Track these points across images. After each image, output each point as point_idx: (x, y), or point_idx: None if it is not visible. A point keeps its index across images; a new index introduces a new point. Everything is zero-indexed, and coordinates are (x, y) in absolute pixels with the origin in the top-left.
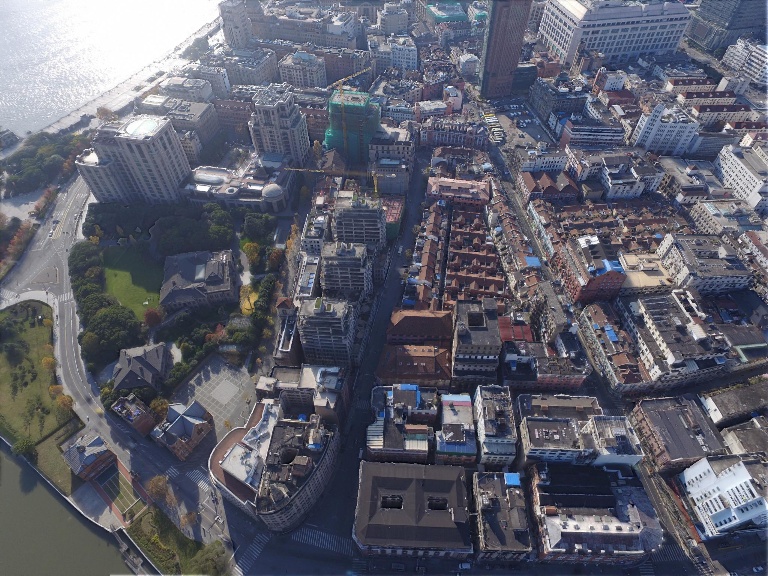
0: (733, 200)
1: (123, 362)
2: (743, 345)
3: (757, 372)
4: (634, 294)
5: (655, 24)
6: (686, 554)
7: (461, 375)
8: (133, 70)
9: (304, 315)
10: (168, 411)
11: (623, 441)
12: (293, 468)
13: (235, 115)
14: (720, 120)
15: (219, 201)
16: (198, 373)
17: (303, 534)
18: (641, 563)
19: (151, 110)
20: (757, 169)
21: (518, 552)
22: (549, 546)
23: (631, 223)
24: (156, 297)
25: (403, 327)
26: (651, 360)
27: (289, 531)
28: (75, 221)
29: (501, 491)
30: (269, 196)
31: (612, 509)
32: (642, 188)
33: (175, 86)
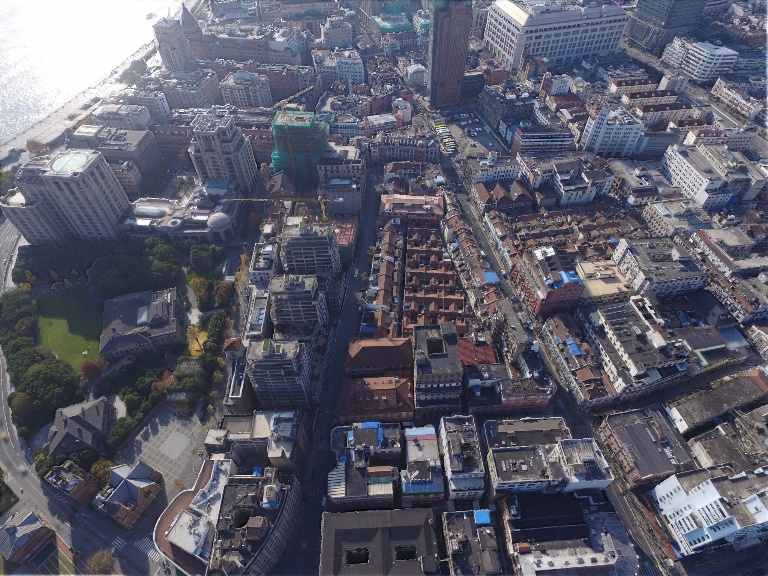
0: (682, 199)
1: (59, 423)
2: (702, 348)
3: (718, 373)
4: (593, 303)
5: (595, 26)
6: (664, 575)
7: (424, 405)
8: (66, 98)
9: (252, 359)
10: (110, 475)
11: (591, 466)
12: (247, 532)
13: (176, 141)
14: (664, 119)
15: (162, 234)
16: (145, 427)
17: None
18: None
19: (84, 141)
20: (702, 167)
21: None
22: None
23: (586, 229)
24: (96, 345)
25: (361, 359)
26: (615, 372)
27: None
28: (4, 267)
29: (471, 531)
30: (215, 226)
31: (586, 539)
32: (594, 192)
33: (109, 114)
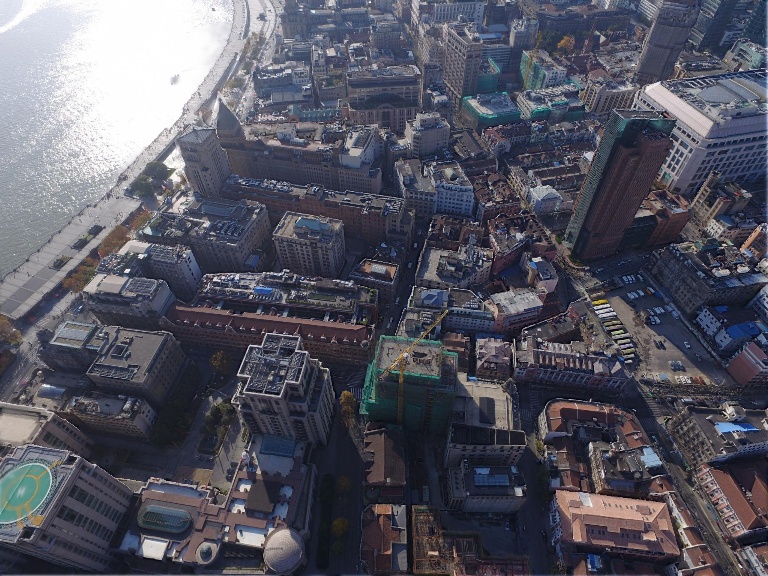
0: None
1: None
2: None
3: None
4: None
5: None
6: None
7: None
8: (54, 227)
9: None
10: None
11: None
12: None
13: (208, 333)
14: None
15: (185, 566)
16: None
17: None
18: None
19: (65, 353)
20: None
21: None
22: None
23: None
24: None
25: None
26: None
27: None
28: None
29: None
30: (278, 570)
31: None
32: None
33: (108, 295)
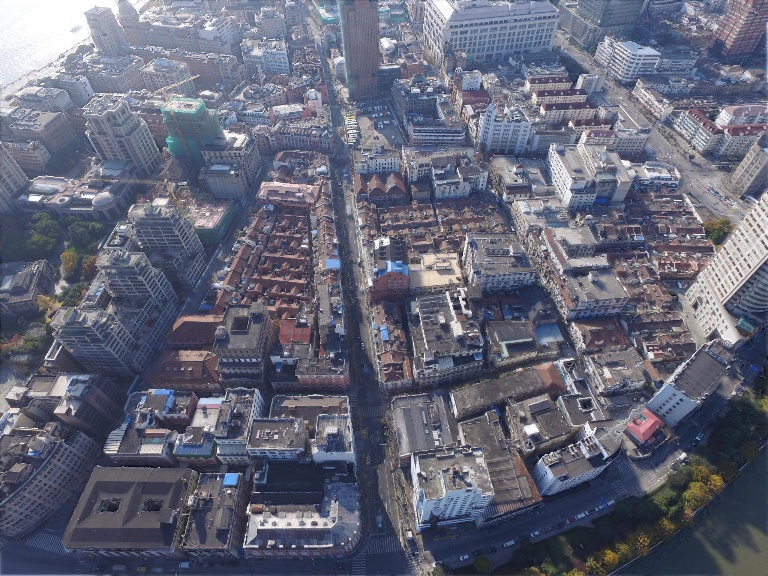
0: (548, 198)
1: None
2: (509, 341)
3: (527, 366)
4: None
5: (523, 23)
6: (402, 546)
7: (227, 378)
8: (8, 79)
9: (54, 325)
10: None
11: (336, 439)
12: (6, 476)
13: None
14: (566, 118)
15: (53, 211)
16: None
17: (38, 539)
18: (356, 556)
19: None
20: (572, 167)
21: (218, 550)
22: (244, 543)
23: (449, 223)
24: None
25: (181, 332)
26: None
27: (22, 537)
28: None
29: (219, 491)
30: (98, 205)
31: (317, 505)
32: (468, 187)
33: (29, 96)
